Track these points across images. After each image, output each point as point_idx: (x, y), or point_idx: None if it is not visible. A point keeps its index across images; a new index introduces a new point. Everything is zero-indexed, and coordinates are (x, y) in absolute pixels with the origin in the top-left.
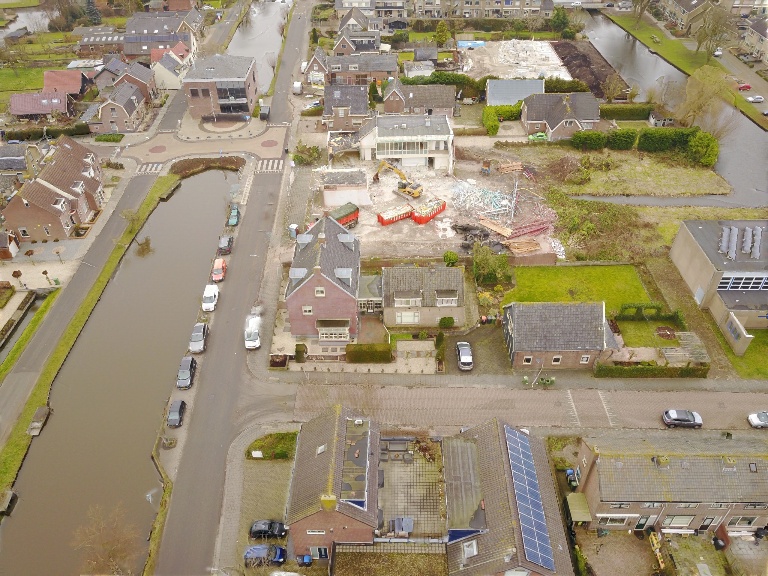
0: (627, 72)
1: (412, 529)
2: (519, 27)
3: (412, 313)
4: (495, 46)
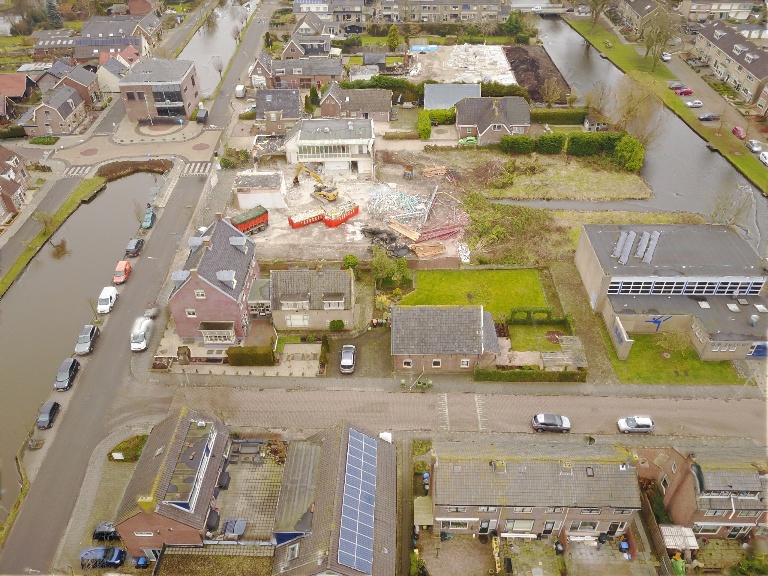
0: (575, 77)
1: (244, 531)
2: (472, 32)
3: (301, 316)
4: (447, 50)
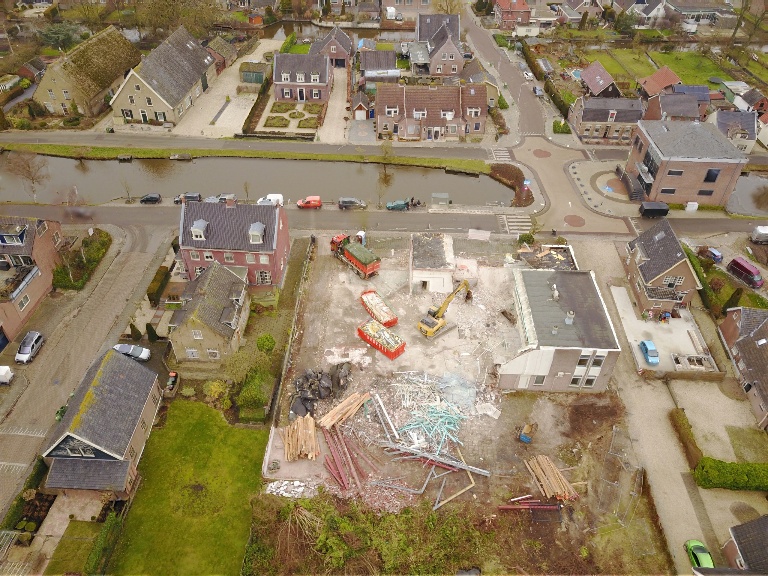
0: None
1: None
2: None
3: None
4: None
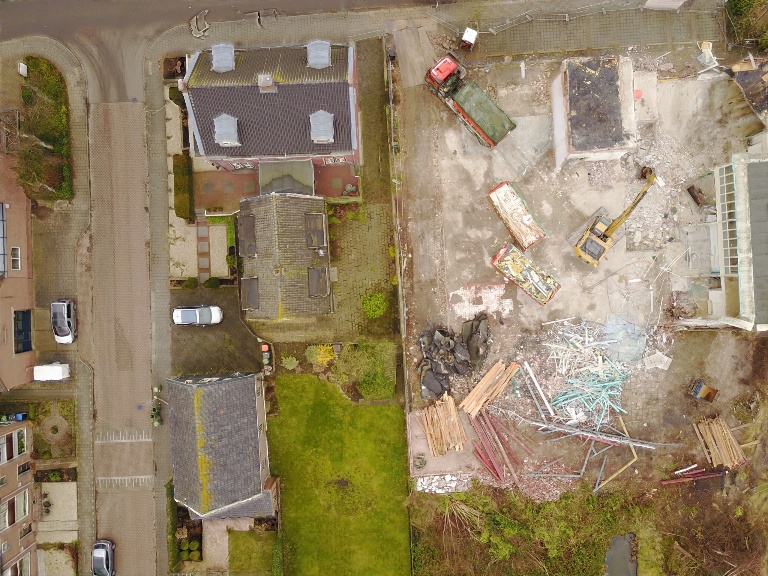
0: None
1: None
2: None
3: None
4: None
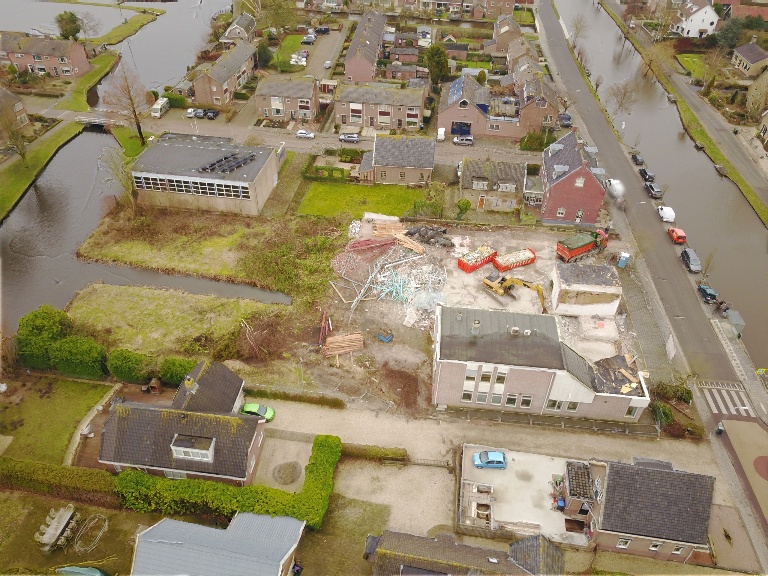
0: None
1: None
2: None
3: None
4: None
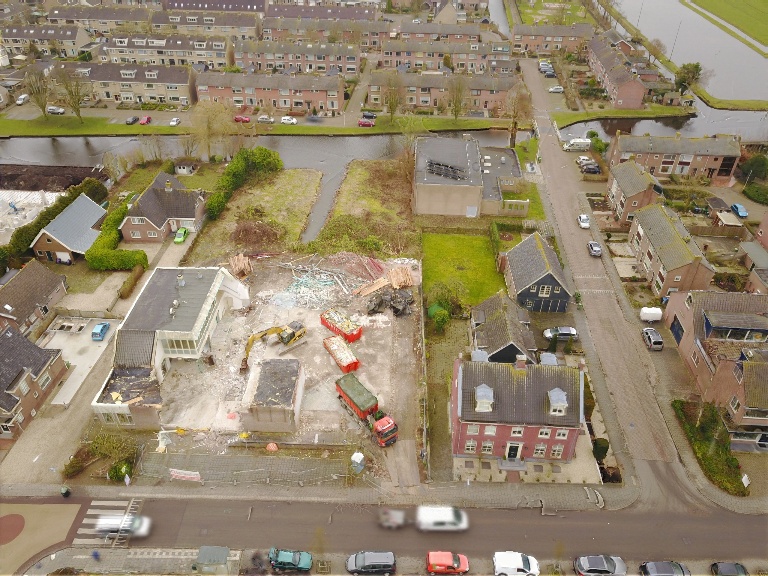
0: None
1: None
2: None
3: None
4: None
